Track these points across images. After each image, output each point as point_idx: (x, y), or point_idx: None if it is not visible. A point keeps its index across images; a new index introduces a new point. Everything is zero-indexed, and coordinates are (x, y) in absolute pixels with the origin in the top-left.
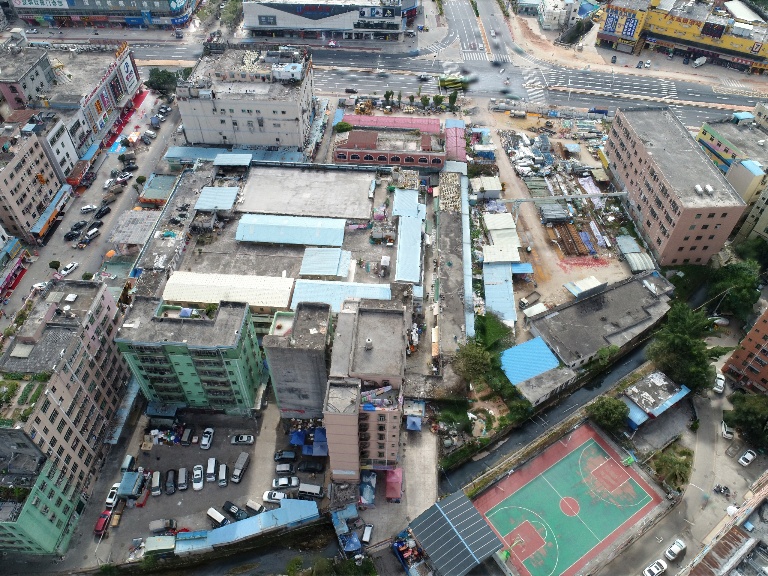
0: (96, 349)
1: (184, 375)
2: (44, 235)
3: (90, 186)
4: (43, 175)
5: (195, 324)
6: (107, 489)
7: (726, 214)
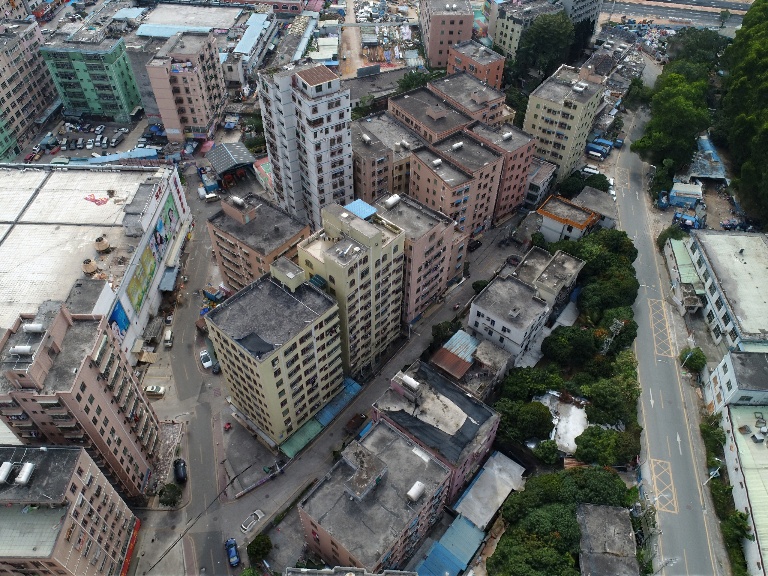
0: (29, 58)
1: (84, 81)
2: None
3: (50, 21)
4: (14, 2)
5: (88, 44)
6: None
7: (462, 22)
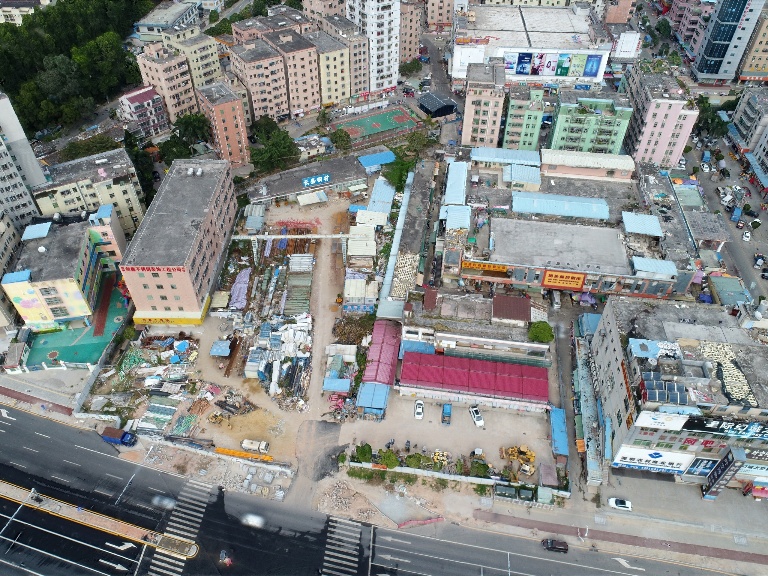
0: None
1: None
2: None
3: None
4: None
5: None
6: None
7: None
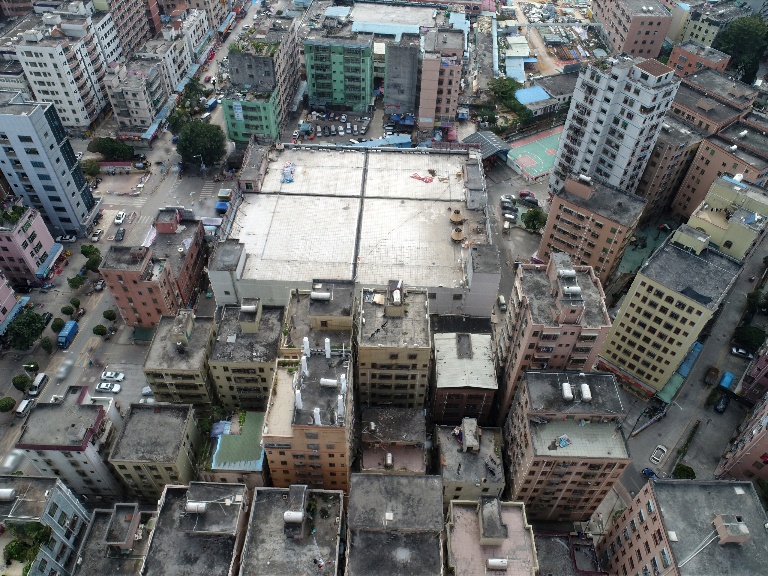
0: (291, 51)
1: (336, 73)
2: (222, 38)
3: (244, 18)
4: None
5: (346, 39)
6: (291, 133)
7: (660, 23)
